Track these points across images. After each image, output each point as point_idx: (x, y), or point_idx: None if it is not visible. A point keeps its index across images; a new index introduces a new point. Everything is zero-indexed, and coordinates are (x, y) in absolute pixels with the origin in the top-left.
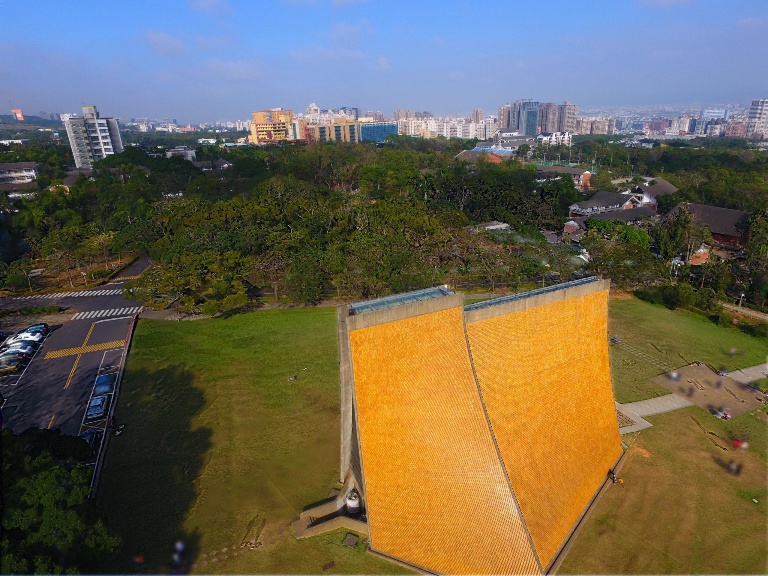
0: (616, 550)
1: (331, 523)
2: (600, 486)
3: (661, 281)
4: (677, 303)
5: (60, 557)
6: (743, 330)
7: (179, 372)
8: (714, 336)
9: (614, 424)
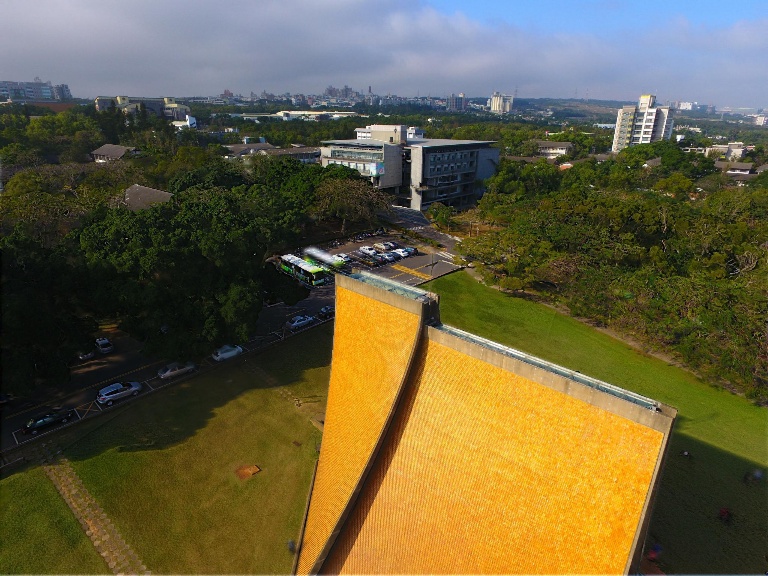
0: None
1: None
2: None
3: None
4: None
5: (225, 325)
6: None
7: None
8: None
9: None
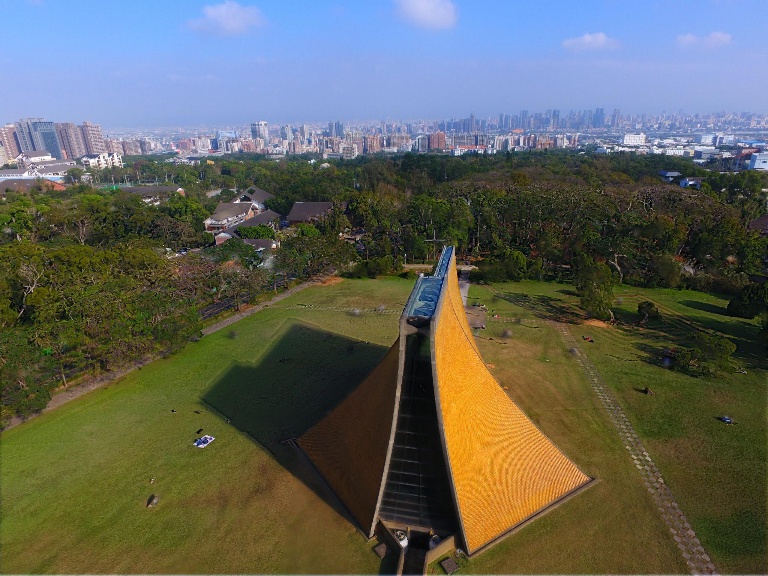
0: (554, 424)
1: (426, 568)
2: None
3: (359, 259)
4: (376, 272)
5: None
6: None
7: None
8: None
9: None
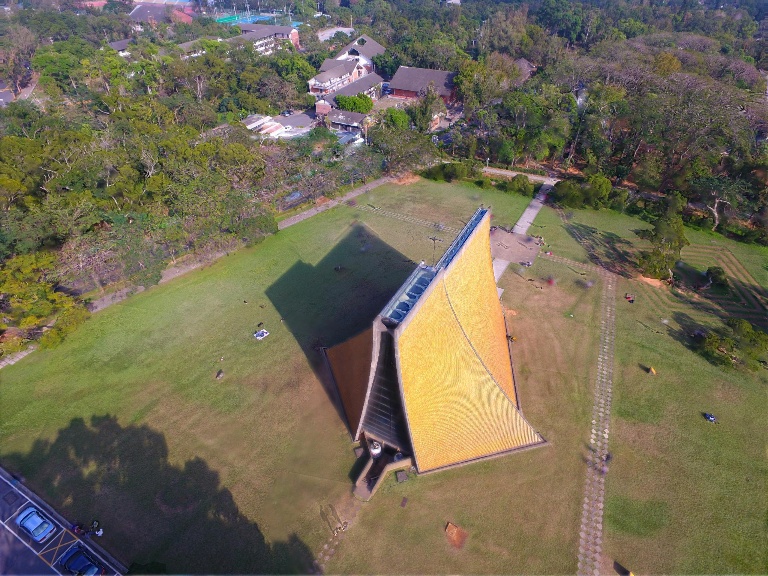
0: (539, 384)
1: (383, 474)
2: (508, 349)
3: (438, 160)
4: (453, 176)
5: None
6: (498, 188)
7: (84, 432)
8: (487, 199)
9: (499, 303)
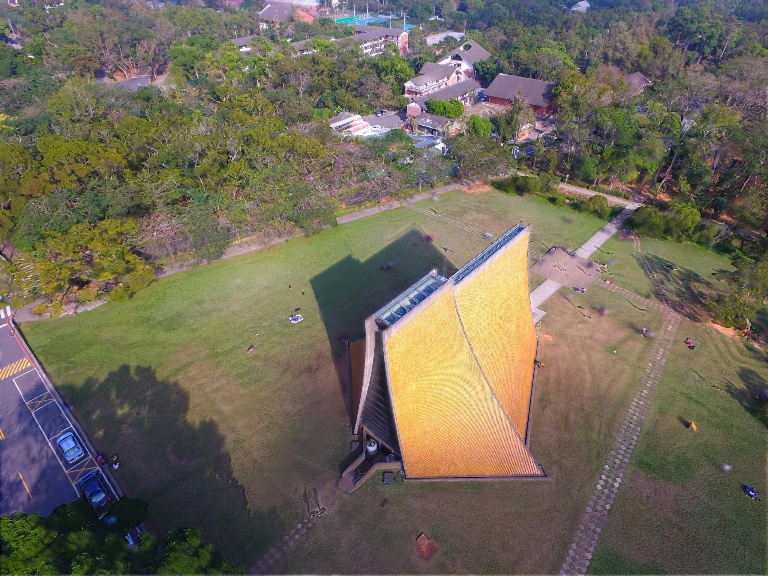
0: (556, 416)
1: (370, 471)
2: (532, 373)
3: (512, 172)
4: (525, 190)
5: None
6: (572, 207)
7: (127, 378)
8: (557, 218)
9: (532, 326)
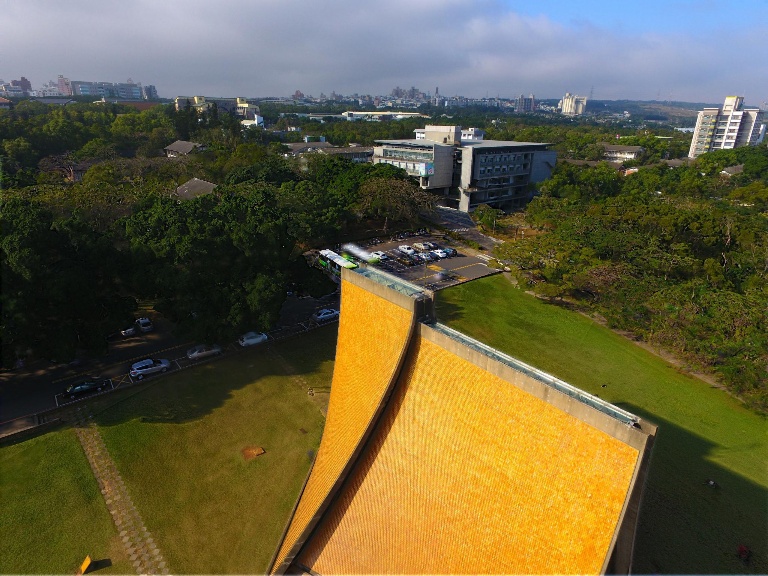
0: None
1: None
2: None
3: None
4: None
5: (250, 313)
6: None
7: (451, 310)
8: None
9: None
